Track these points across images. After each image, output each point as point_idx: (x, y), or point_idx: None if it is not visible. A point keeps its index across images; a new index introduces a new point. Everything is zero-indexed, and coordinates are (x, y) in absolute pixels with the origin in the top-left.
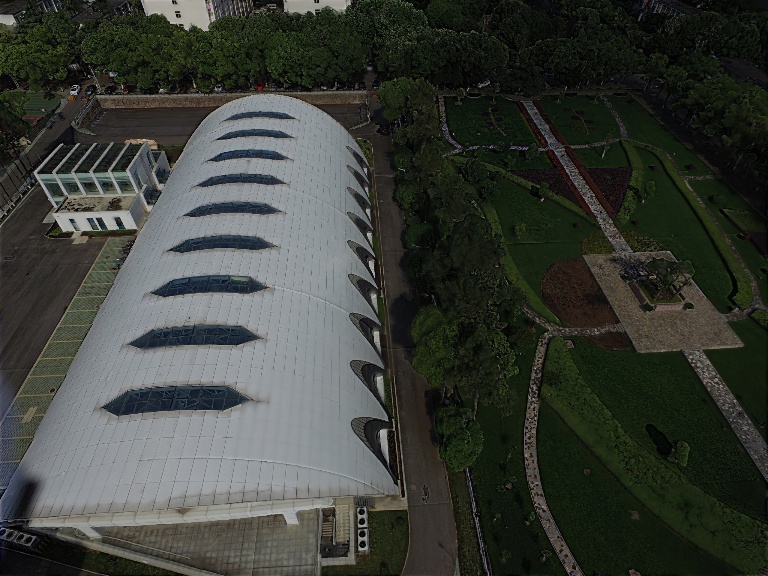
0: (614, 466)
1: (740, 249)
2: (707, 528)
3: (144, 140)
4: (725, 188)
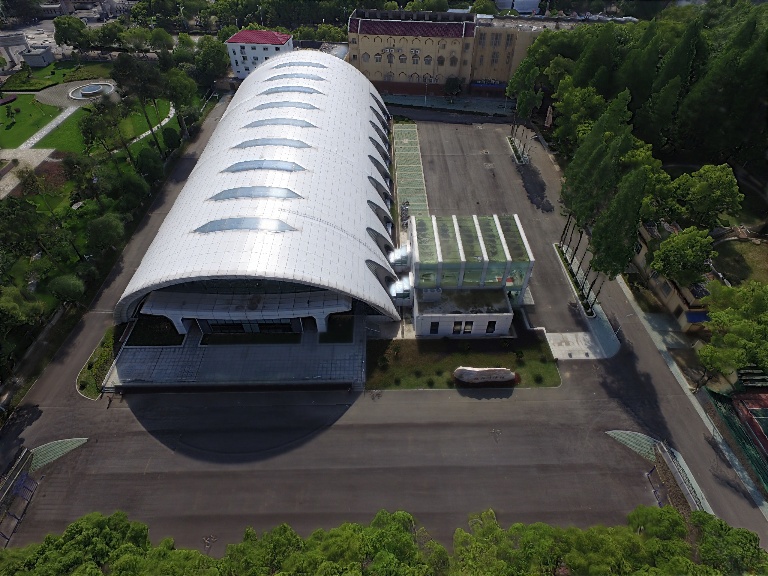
0: None
1: None
2: None
3: (476, 369)
4: None
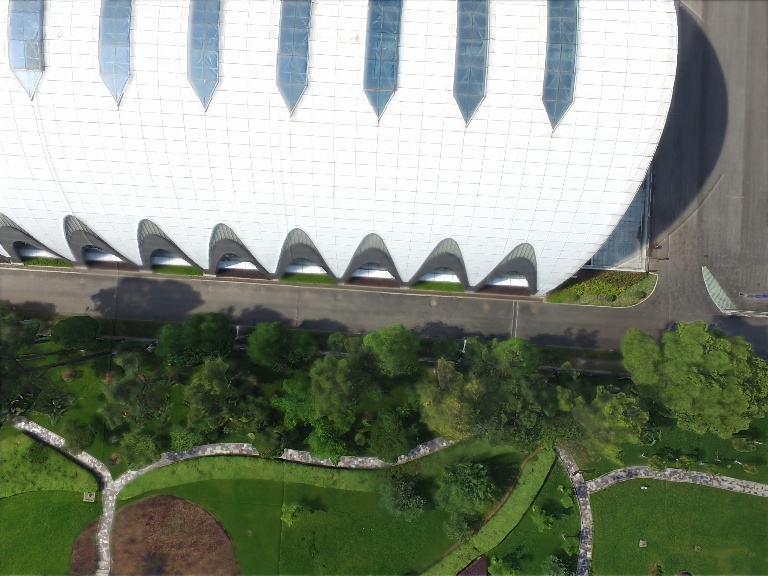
0: None
1: None
2: None
3: None
4: None
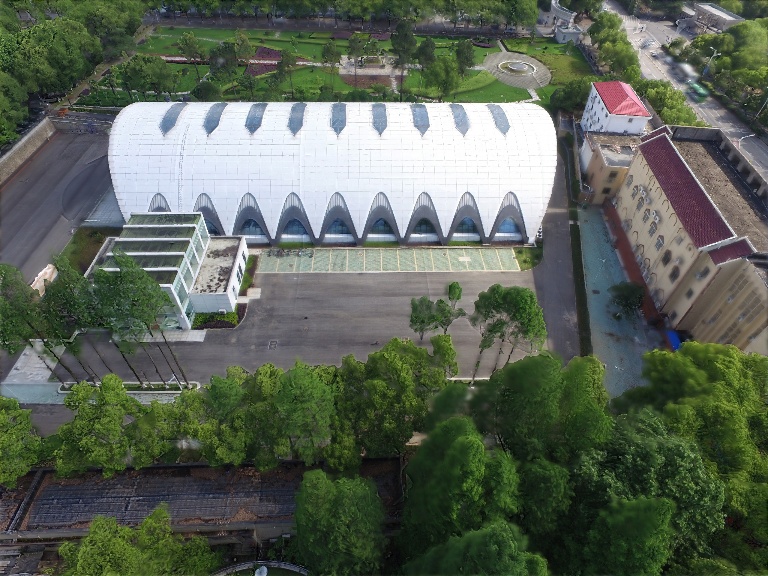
0: None
1: (342, 42)
2: (484, 80)
3: (42, 273)
4: (290, 32)
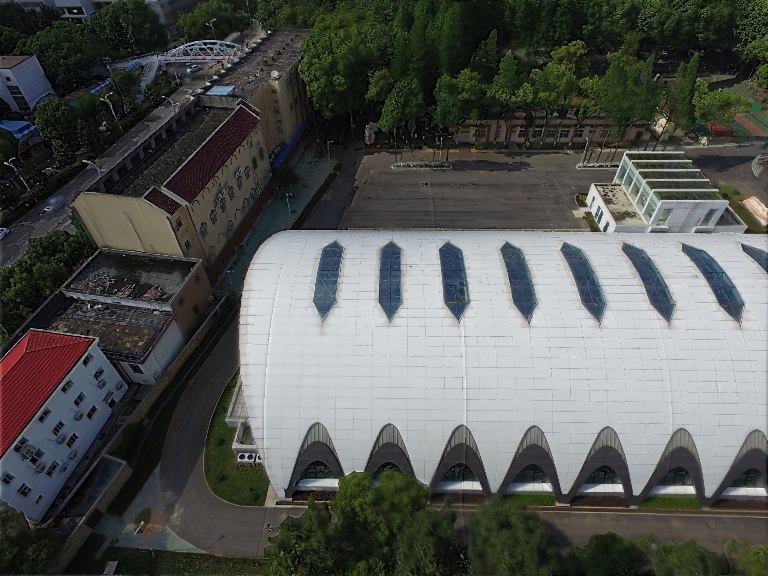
0: None
1: None
2: None
3: (766, 209)
4: None
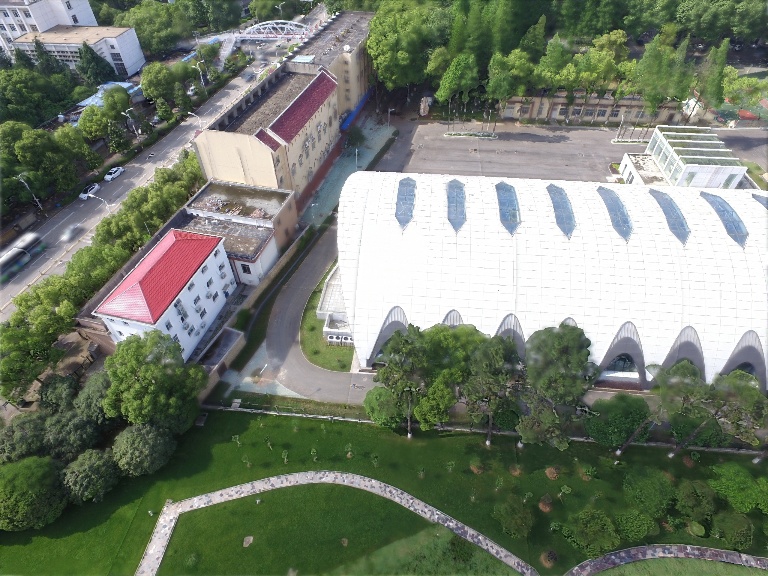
0: (341, 574)
1: None
2: None
3: None
4: None
